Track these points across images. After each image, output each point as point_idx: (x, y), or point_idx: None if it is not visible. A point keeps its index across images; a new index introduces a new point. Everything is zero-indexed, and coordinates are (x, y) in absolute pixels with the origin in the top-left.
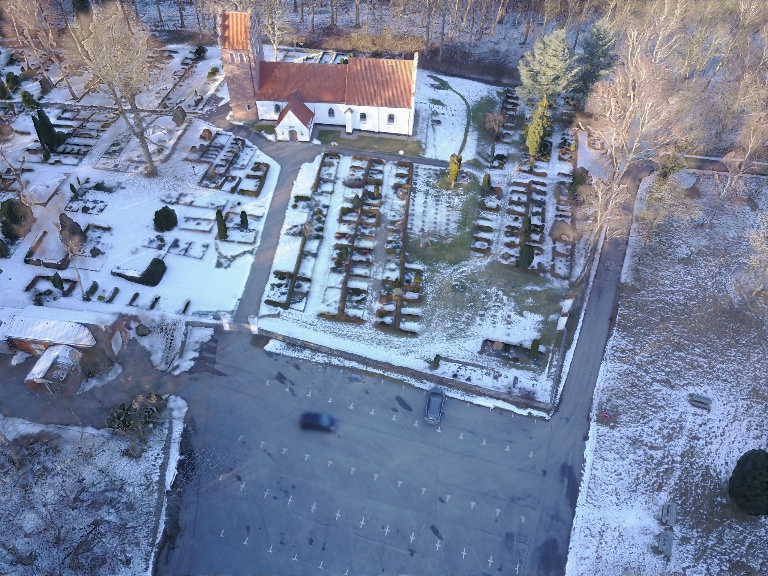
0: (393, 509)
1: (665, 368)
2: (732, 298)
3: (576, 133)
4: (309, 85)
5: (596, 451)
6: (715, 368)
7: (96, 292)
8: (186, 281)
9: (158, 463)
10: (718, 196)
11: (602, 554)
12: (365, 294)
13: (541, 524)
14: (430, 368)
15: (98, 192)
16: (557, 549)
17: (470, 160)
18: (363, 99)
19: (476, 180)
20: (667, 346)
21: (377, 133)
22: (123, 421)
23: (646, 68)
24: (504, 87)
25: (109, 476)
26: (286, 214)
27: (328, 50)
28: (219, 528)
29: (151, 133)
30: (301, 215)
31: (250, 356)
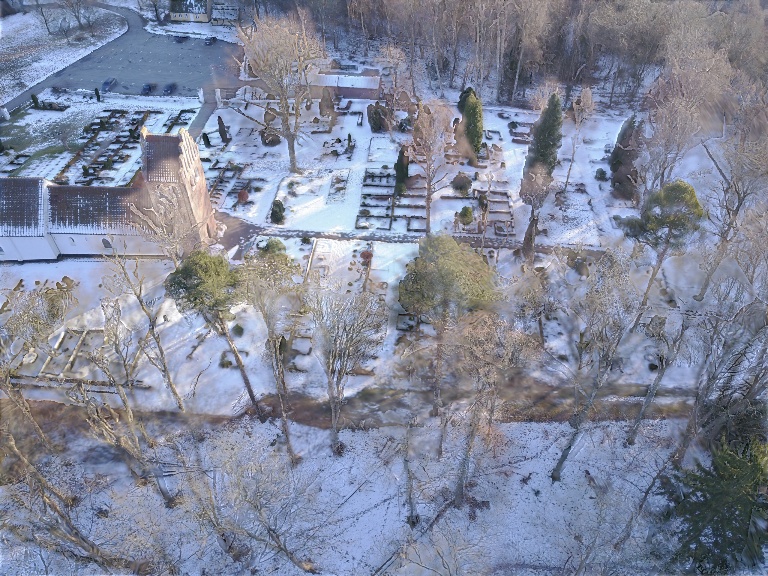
0: None
1: None
2: None
3: None
4: None
5: None
6: None
7: None
8: None
9: None
10: None
11: None
12: None
13: None
14: None
15: None
16: None
17: None
18: None
19: None
20: None
21: None
22: None
23: None
24: None
25: None
26: None
27: None
28: None
29: None
30: None
31: None
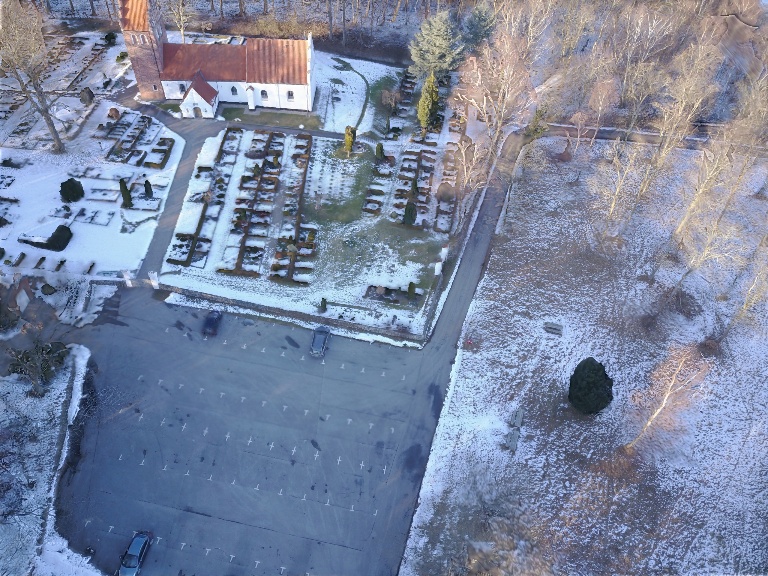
0: (278, 429)
1: (526, 302)
2: (590, 243)
3: (467, 108)
4: (211, 65)
5: (460, 372)
6: (569, 301)
7: (3, 258)
8: (91, 245)
9: (60, 401)
10: (587, 159)
11: (458, 452)
12: (262, 251)
13: (408, 433)
14: (318, 312)
15: (5, 168)
16: (420, 452)
17: (366, 132)
18: (262, 77)
19: (371, 150)
20: (529, 284)
21: (279, 109)
22: (21, 358)
23: (509, 42)
24: (404, 68)
25: (13, 414)
26: (189, 183)
27: (237, 36)
28: (118, 453)
29: (55, 110)
30: (204, 184)
31: (151, 308)
